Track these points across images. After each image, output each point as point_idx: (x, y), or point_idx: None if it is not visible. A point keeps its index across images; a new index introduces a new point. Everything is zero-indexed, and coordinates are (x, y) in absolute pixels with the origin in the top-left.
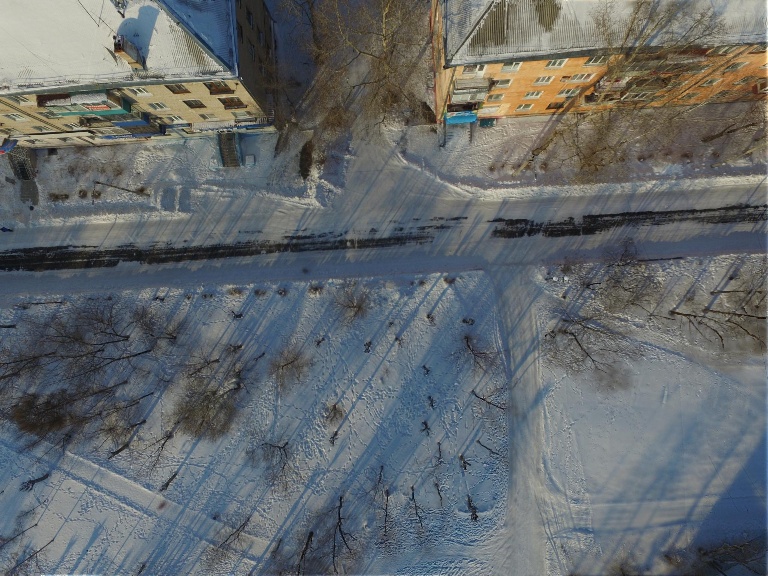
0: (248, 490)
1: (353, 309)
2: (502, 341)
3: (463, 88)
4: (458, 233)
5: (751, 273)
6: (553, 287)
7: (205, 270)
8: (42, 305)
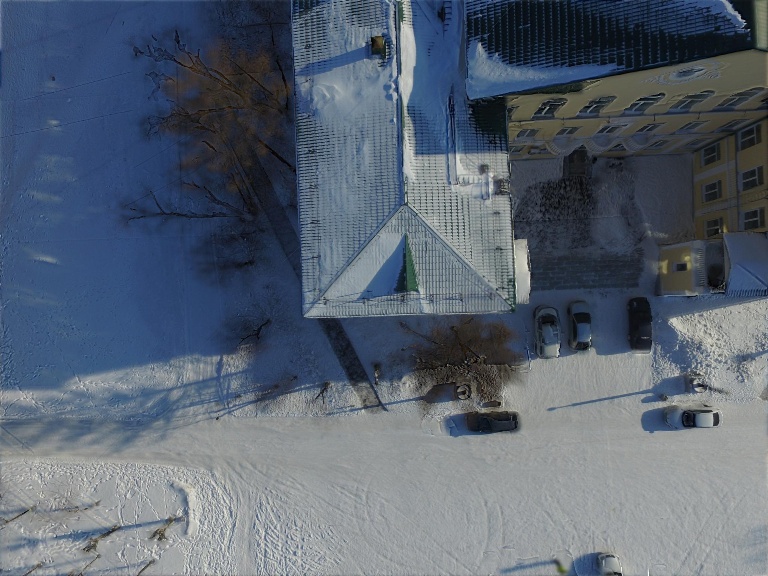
0: None
1: None
2: None
3: None
4: None
5: None
6: None
7: None
8: None
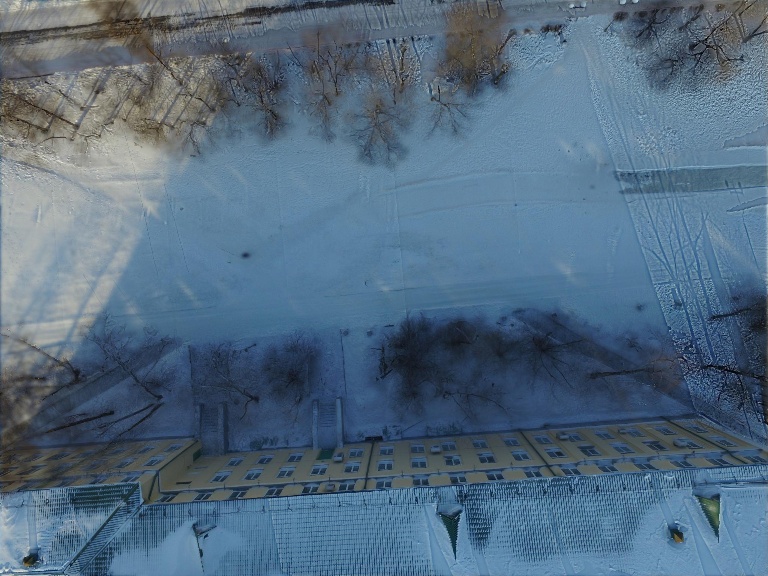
0: None
1: None
2: None
3: None
4: None
5: (117, 86)
6: None
7: None
8: None
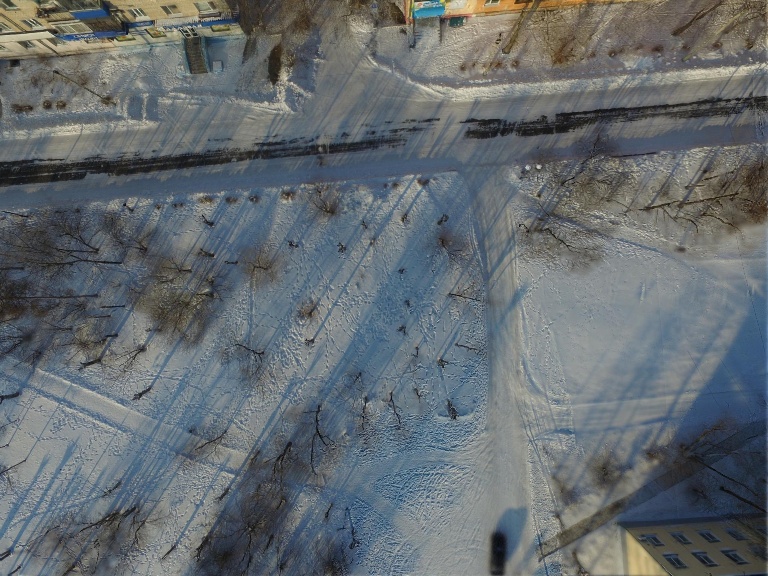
0: (224, 402)
1: (326, 214)
2: (478, 242)
3: None
4: (431, 135)
5: (725, 166)
6: (528, 186)
7: (175, 180)
8: (8, 220)
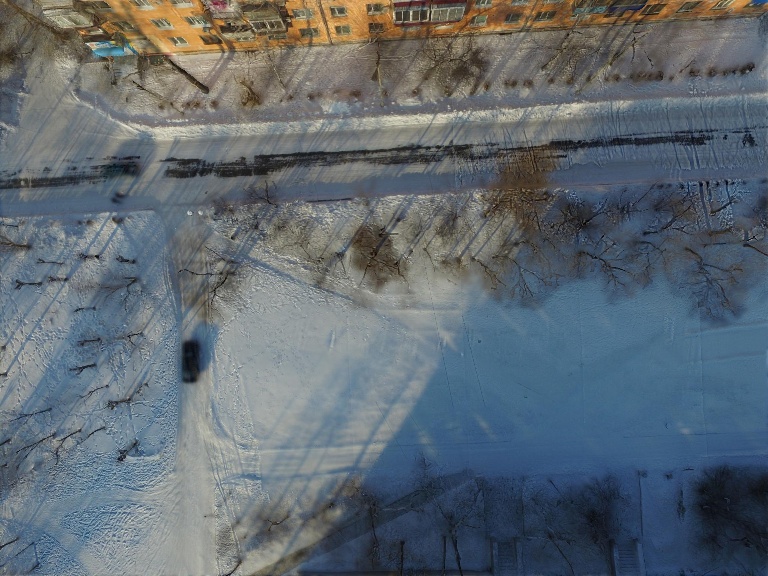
0: None
1: (24, 249)
2: (172, 283)
3: (46, 8)
4: (131, 173)
5: (418, 215)
6: (223, 228)
7: None
8: None
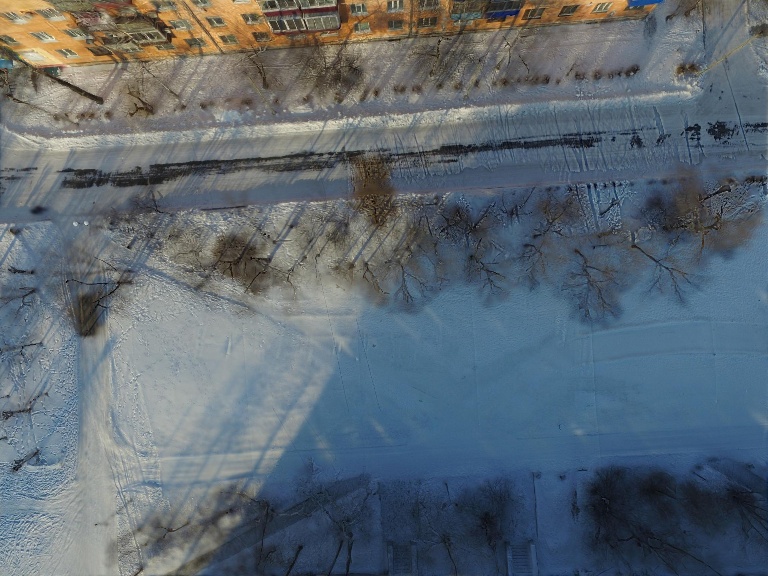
0: None
1: None
2: (70, 292)
3: None
4: (29, 184)
5: (311, 221)
6: (119, 237)
7: None
8: None
